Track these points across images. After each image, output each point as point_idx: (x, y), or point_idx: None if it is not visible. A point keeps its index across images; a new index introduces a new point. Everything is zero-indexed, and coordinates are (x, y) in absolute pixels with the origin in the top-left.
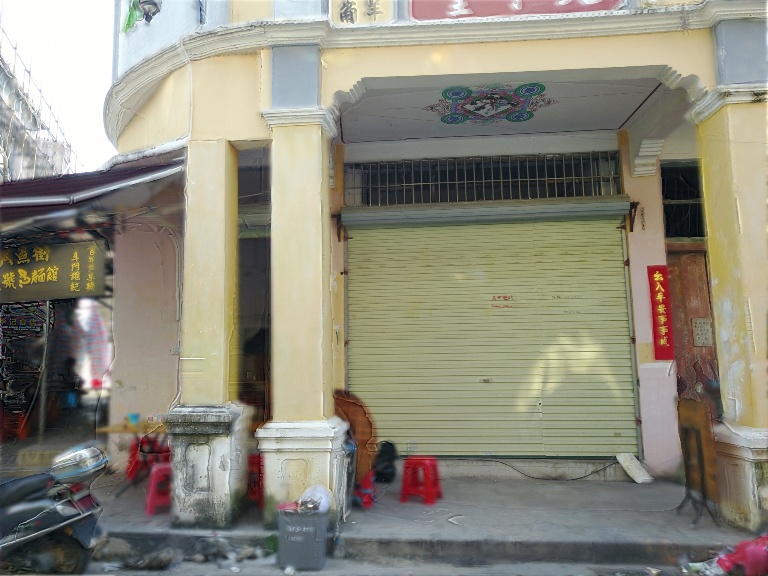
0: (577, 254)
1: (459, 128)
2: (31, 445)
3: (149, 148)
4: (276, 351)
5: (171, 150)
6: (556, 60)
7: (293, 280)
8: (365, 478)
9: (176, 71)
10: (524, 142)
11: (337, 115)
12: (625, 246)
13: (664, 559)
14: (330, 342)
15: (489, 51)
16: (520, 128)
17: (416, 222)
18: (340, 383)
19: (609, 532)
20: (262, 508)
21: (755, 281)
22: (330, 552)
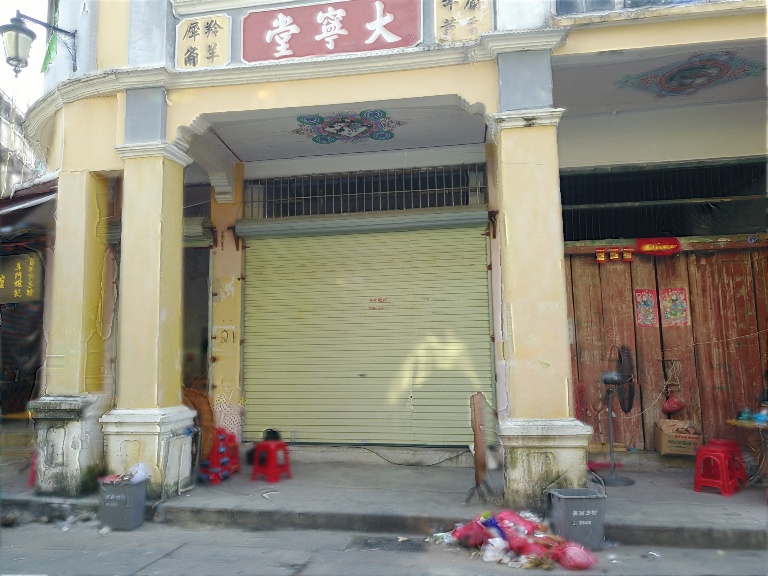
0: (449, 259)
1: (333, 147)
2: None
3: None
4: (121, 350)
5: (50, 180)
6: (361, 93)
7: (136, 290)
8: (212, 459)
9: (58, 111)
10: (399, 157)
11: (184, 146)
12: (489, 252)
13: (419, 530)
14: (172, 342)
15: (305, 87)
16: (390, 145)
17: (301, 232)
18: (235, 377)
19: (384, 507)
20: None
21: (517, 288)
22: (148, 518)
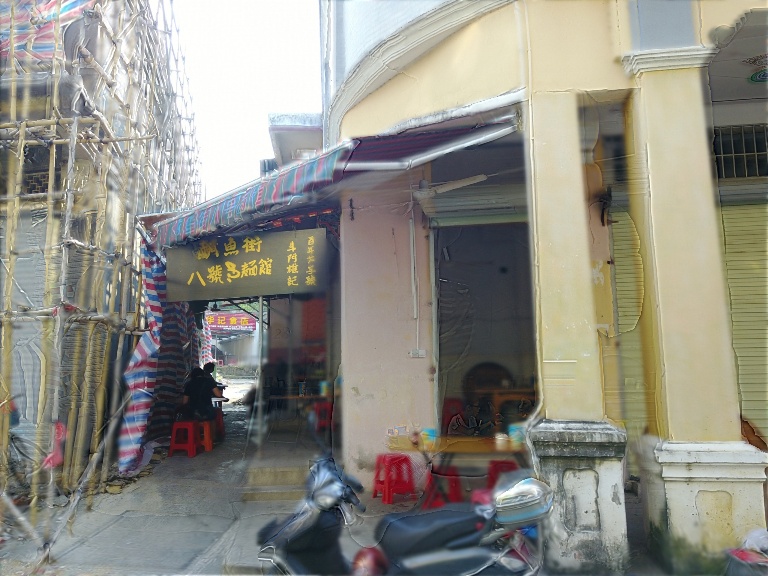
0: None
1: (766, 87)
2: (263, 461)
3: (424, 113)
4: (671, 352)
5: (497, 107)
6: None
7: (688, 262)
8: None
9: (490, 13)
10: None
11: None
12: None
13: None
14: None
15: None
16: None
17: None
18: None
19: None
20: (674, 554)
21: None
22: None
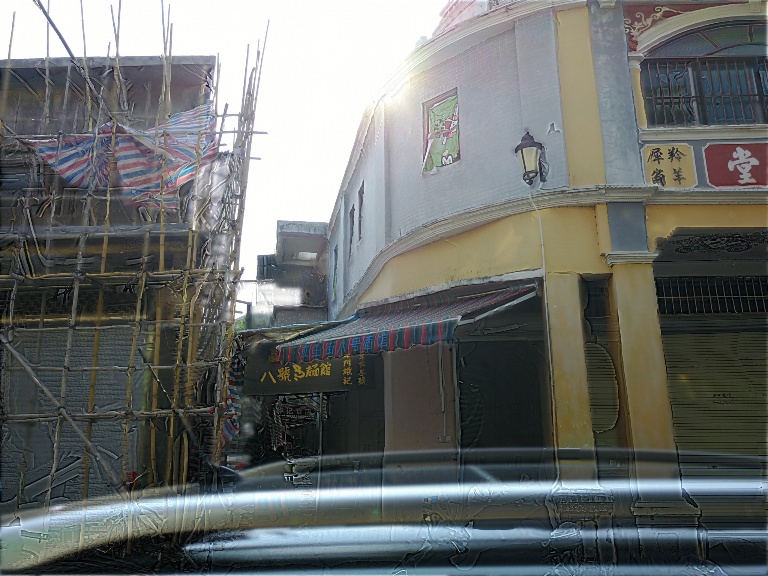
0: None
1: (685, 255)
2: (331, 524)
3: (463, 270)
4: (638, 443)
5: (522, 278)
6: None
7: (645, 386)
8: None
9: (514, 215)
10: (727, 266)
11: None
12: None
13: None
14: None
15: None
16: (730, 256)
17: None
18: None
19: None
20: (645, 575)
21: None
22: None
